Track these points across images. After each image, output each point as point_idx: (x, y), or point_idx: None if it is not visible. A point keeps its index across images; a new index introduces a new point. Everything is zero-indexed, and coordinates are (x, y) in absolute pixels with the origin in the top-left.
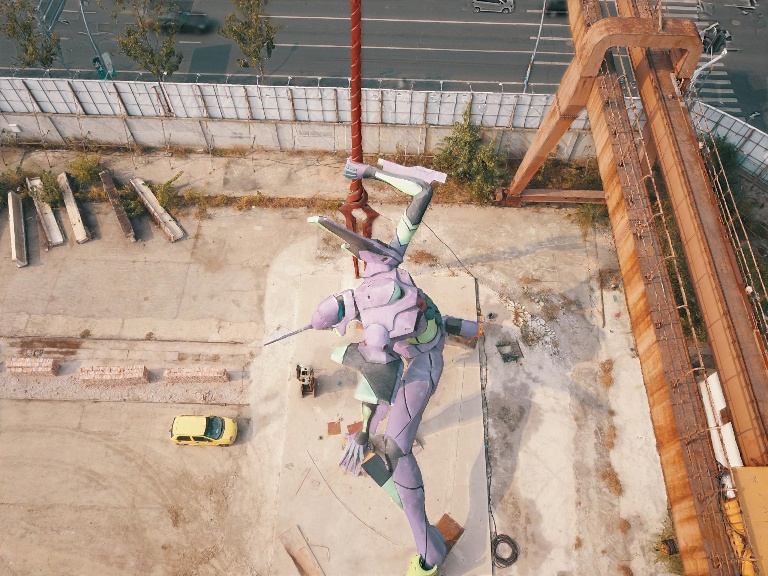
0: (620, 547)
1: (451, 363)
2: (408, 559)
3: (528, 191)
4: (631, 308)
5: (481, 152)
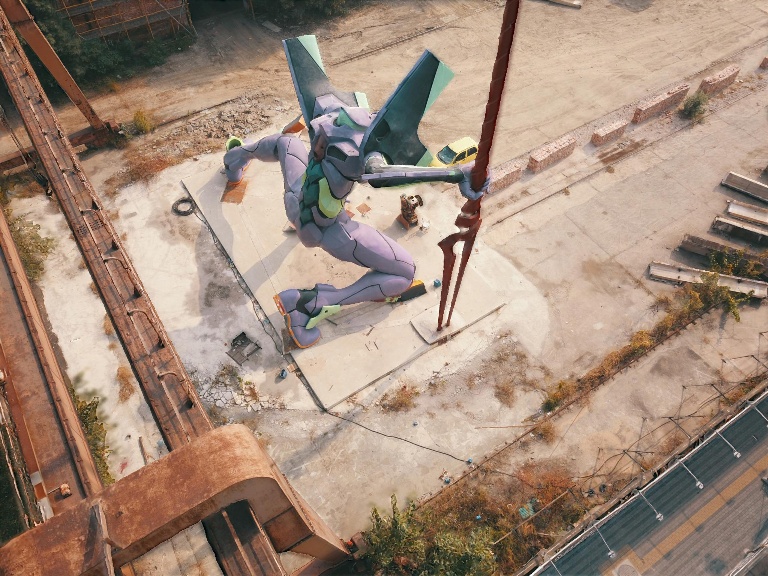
0: None
1: None
2: (254, 171)
3: (317, 569)
4: None
5: (419, 545)
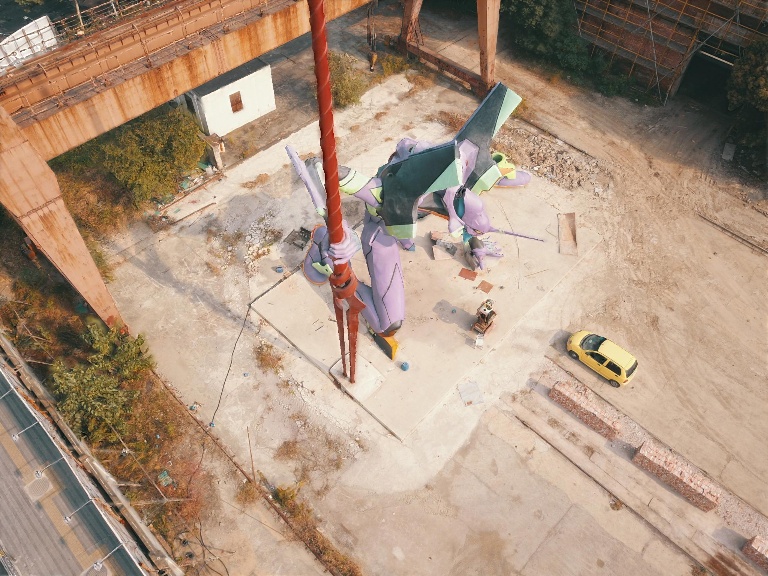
0: (368, 125)
1: (351, 262)
2: (497, 193)
3: None
4: (278, 42)
5: (96, 358)
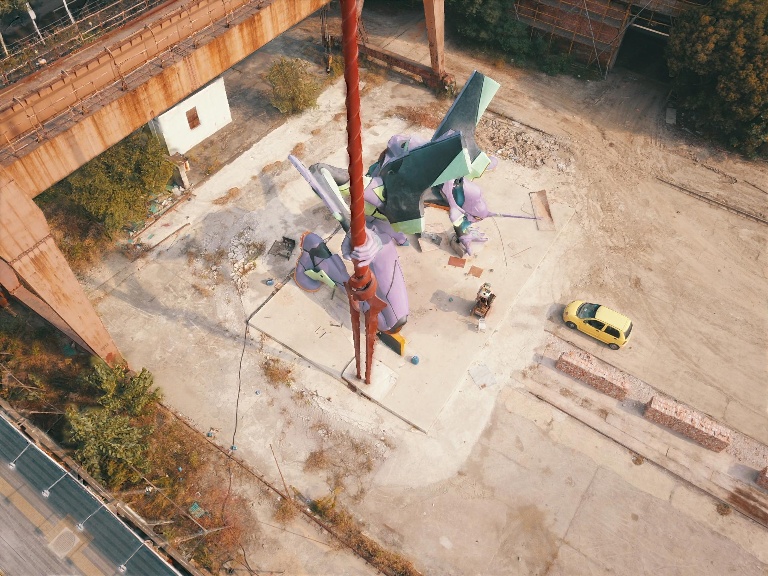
0: (329, 127)
1: None
2: None
3: None
4: (245, 53)
5: (106, 399)
